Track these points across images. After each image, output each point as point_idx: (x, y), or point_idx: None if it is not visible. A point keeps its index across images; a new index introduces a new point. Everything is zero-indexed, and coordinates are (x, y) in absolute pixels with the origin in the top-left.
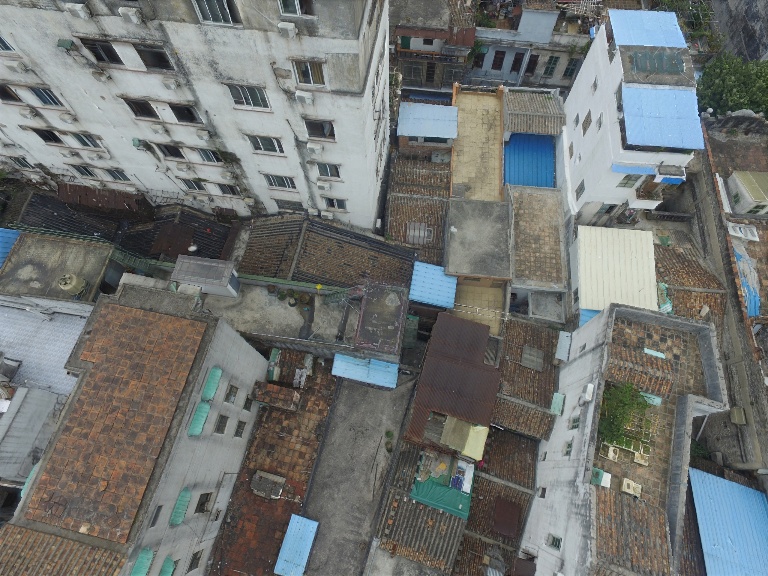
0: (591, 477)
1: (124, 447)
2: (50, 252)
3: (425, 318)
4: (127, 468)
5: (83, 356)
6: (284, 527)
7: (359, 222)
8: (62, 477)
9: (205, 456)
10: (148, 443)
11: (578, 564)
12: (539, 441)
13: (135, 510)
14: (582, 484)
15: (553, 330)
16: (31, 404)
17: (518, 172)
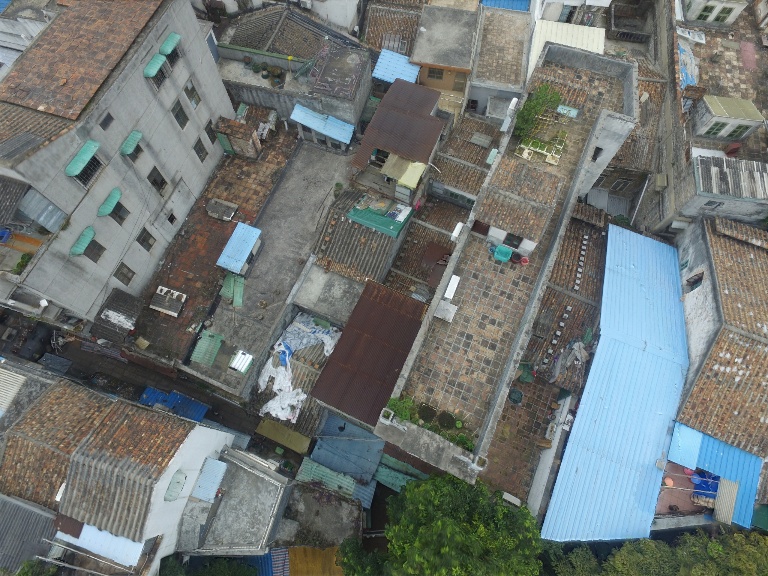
0: None
1: (85, 60)
2: None
3: None
4: (85, 73)
5: (59, 1)
6: None
7: (336, 17)
8: (29, 75)
9: (161, 127)
10: (106, 59)
11: None
12: None
13: (87, 100)
14: None
15: None
16: None
17: (494, 3)
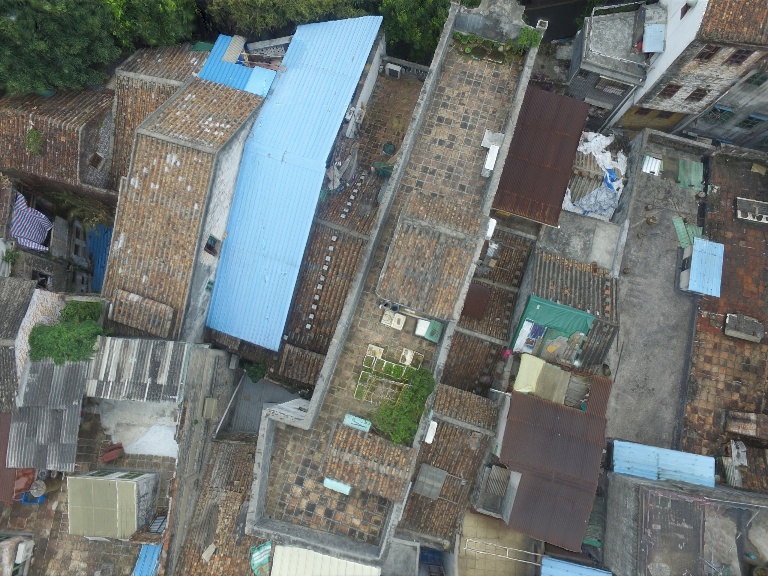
0: (440, 330)
1: None
2: None
3: None
4: None
5: None
6: None
7: None
8: None
9: None
10: None
11: None
12: None
13: None
14: None
15: None
16: None
17: None
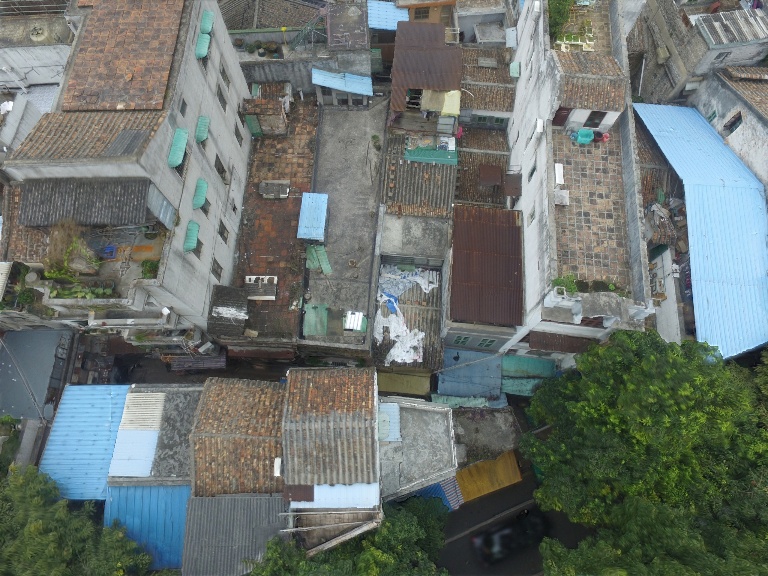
0: None
1: (140, 52)
2: (12, 29)
3: (386, 63)
4: (147, 63)
5: (80, 3)
6: (298, 217)
7: None
8: (88, 79)
9: (213, 112)
10: (162, 46)
11: (551, 96)
12: (506, 126)
13: (164, 87)
14: (544, 61)
15: (501, 50)
16: (33, 119)
17: None
